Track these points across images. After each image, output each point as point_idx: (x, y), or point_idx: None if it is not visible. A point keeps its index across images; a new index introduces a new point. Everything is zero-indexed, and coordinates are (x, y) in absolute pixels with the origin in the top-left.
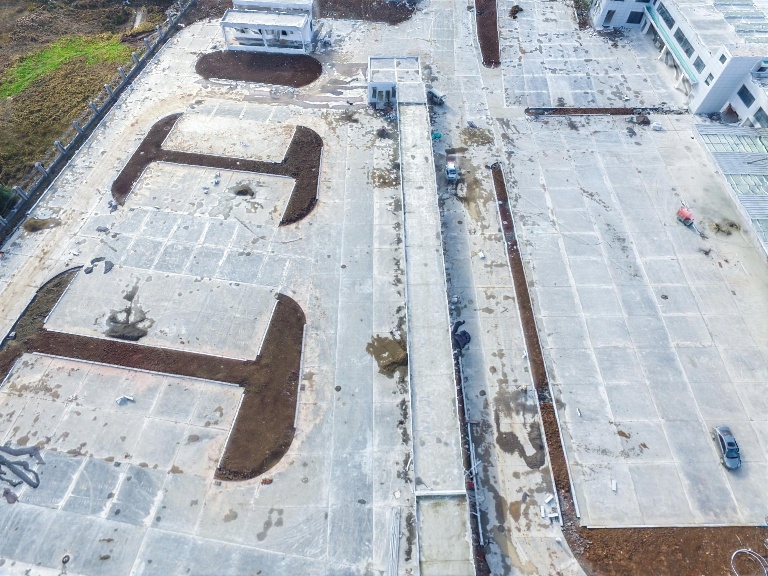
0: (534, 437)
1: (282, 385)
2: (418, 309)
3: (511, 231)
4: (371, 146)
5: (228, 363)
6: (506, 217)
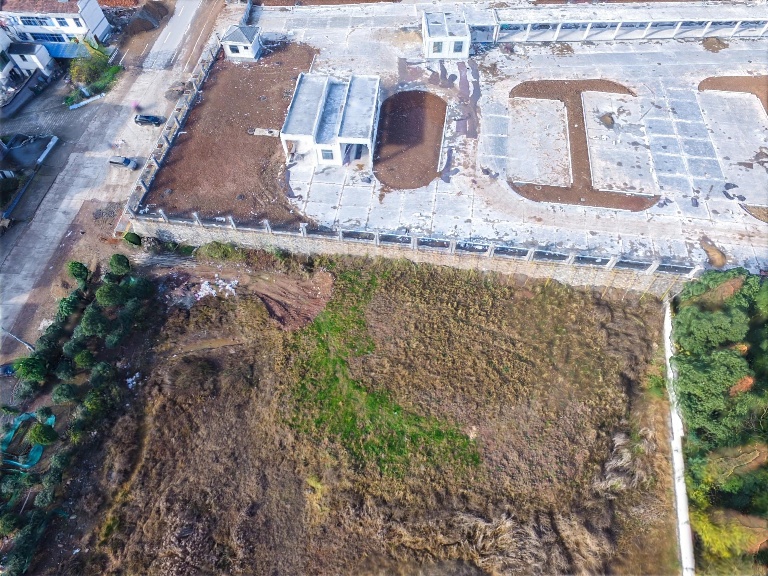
0: (732, 3)
1: (765, 81)
2: (698, 16)
3: (593, 1)
4: (526, 56)
5: (767, 104)
6: (581, 2)
